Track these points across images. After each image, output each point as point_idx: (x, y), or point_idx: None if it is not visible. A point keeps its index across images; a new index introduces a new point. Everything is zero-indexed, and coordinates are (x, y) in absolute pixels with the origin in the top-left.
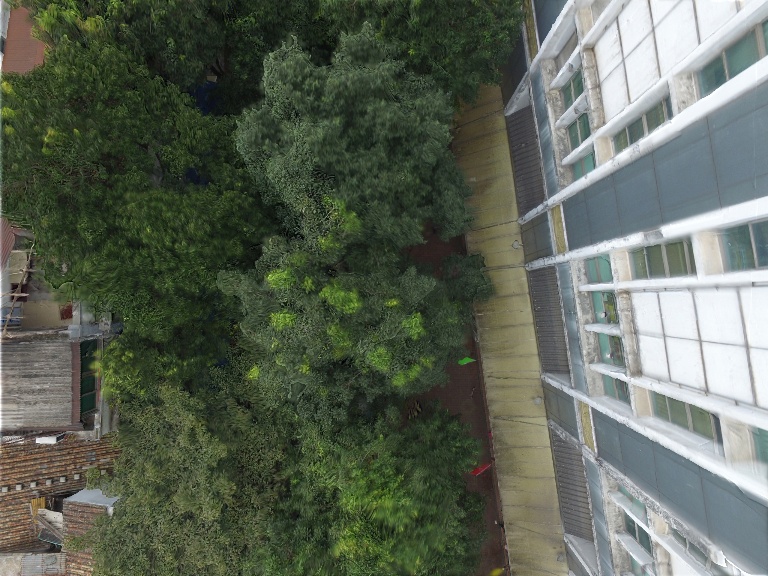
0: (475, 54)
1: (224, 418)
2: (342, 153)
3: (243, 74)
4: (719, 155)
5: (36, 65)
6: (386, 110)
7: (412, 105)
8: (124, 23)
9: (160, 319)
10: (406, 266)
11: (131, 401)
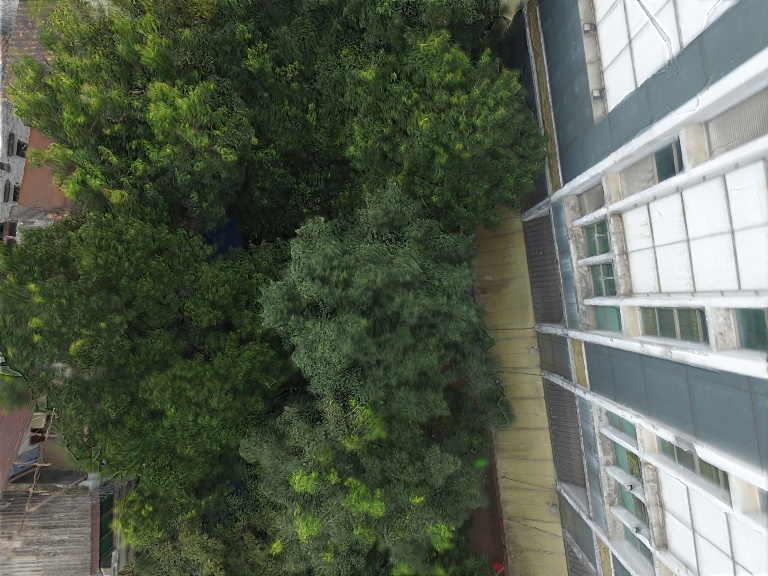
0: (498, 194)
1: (241, 549)
2: (370, 346)
3: (262, 199)
4: (761, 420)
5: (59, 223)
6: (415, 302)
7: (439, 281)
8: (148, 181)
9: (181, 477)
10: (431, 441)
11: None
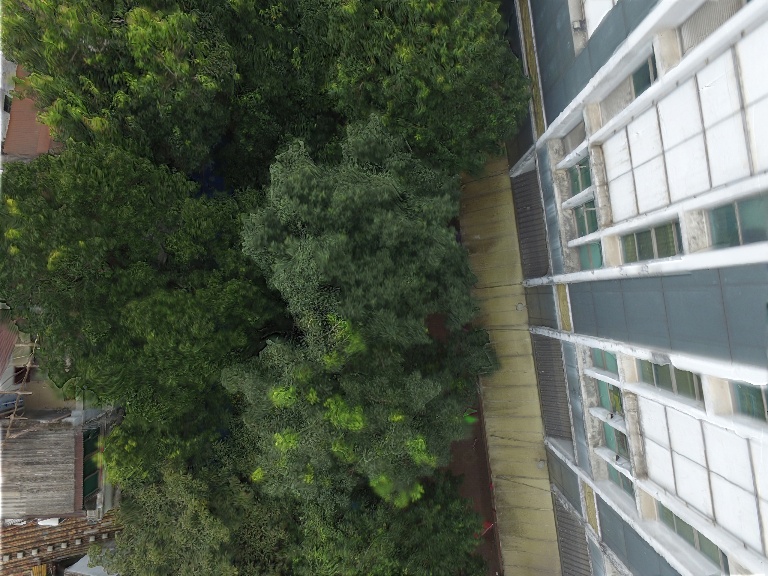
0: (482, 135)
1: (226, 494)
2: (348, 266)
3: (248, 146)
4: (730, 310)
5: (41, 156)
6: (393, 222)
7: (419, 208)
8: (130, 114)
9: (164, 411)
10: (411, 368)
11: (133, 478)
